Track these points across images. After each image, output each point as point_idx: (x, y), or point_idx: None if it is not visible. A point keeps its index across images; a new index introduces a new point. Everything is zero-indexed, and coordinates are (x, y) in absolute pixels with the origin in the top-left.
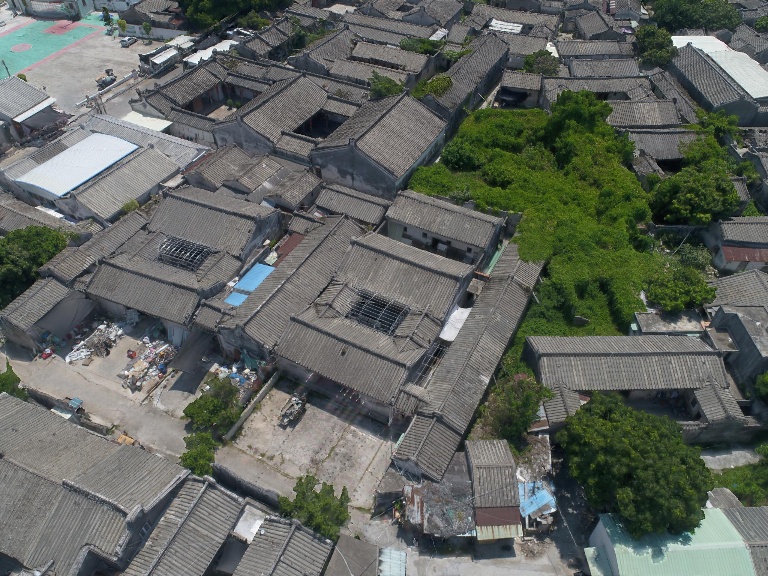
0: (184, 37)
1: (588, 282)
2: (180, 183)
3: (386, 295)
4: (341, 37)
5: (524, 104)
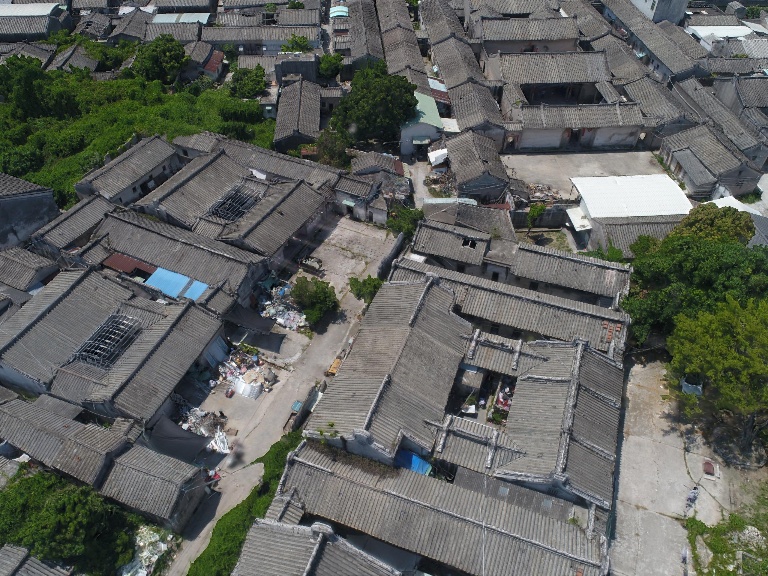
0: None
1: None
2: None
3: (220, 197)
4: None
5: None
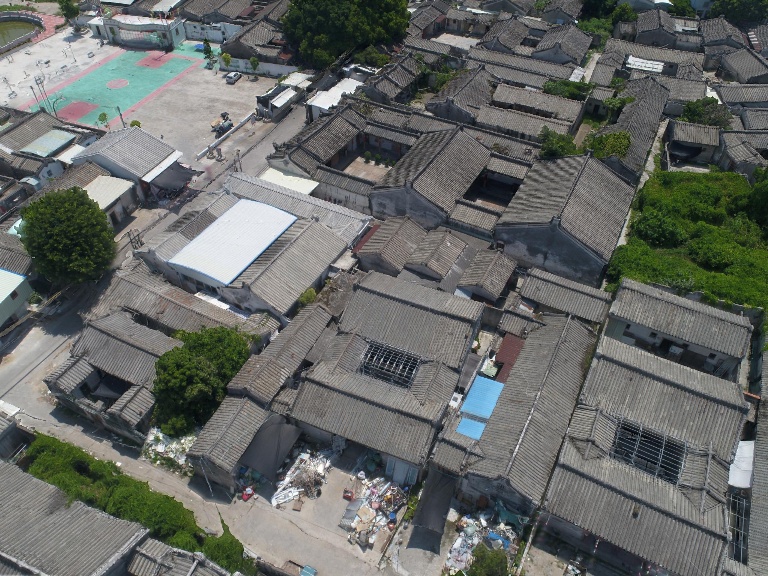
0: (299, 75)
1: None
2: (353, 264)
3: (652, 426)
4: (478, 79)
5: (695, 159)
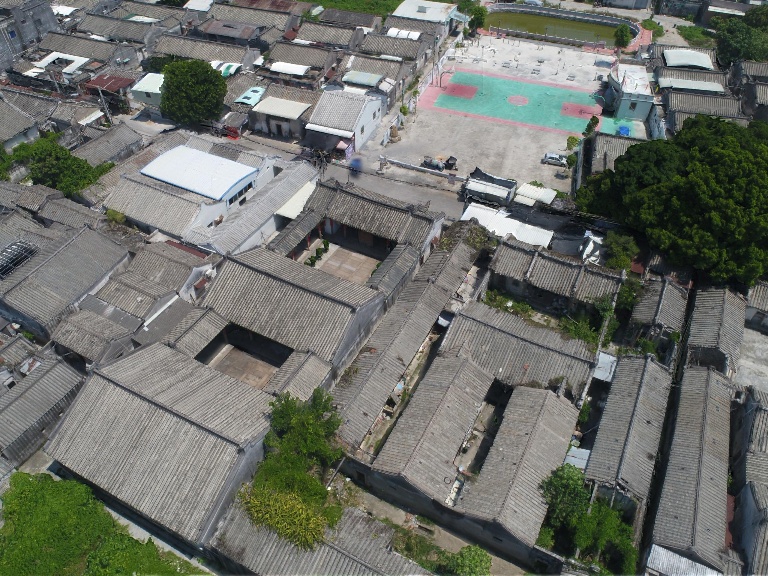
0: (549, 194)
1: None
2: None
3: None
4: (557, 360)
5: None
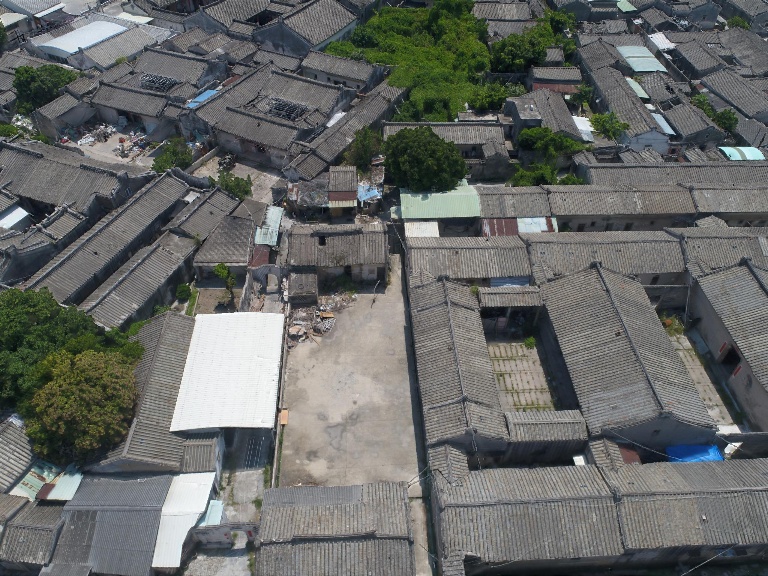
0: None
1: (434, 100)
2: None
3: None
4: None
5: None
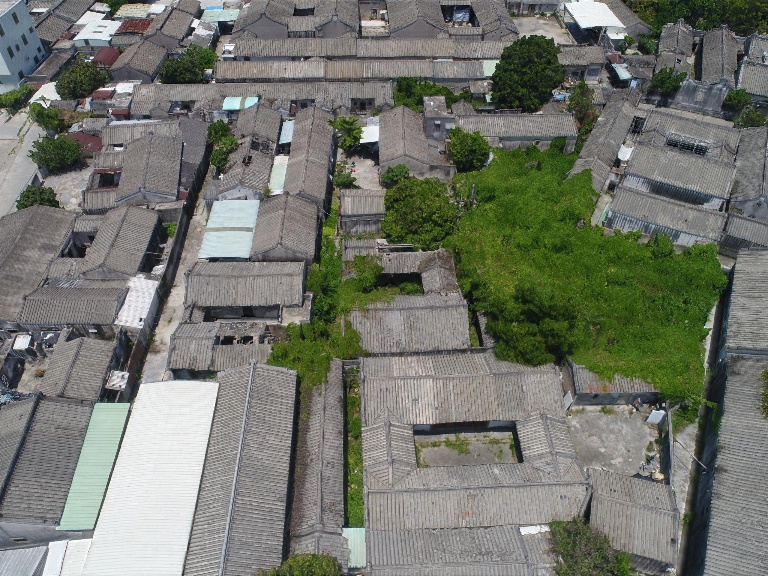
0: None
1: None
2: None
3: None
4: None
5: None
